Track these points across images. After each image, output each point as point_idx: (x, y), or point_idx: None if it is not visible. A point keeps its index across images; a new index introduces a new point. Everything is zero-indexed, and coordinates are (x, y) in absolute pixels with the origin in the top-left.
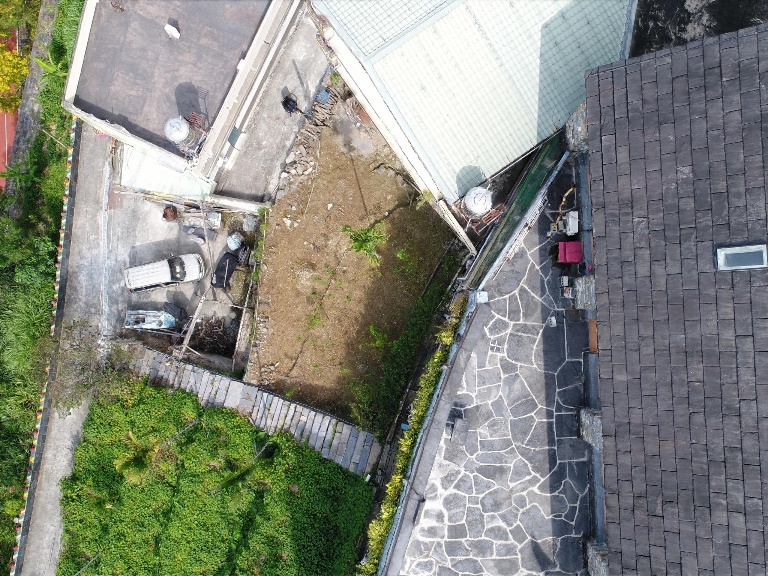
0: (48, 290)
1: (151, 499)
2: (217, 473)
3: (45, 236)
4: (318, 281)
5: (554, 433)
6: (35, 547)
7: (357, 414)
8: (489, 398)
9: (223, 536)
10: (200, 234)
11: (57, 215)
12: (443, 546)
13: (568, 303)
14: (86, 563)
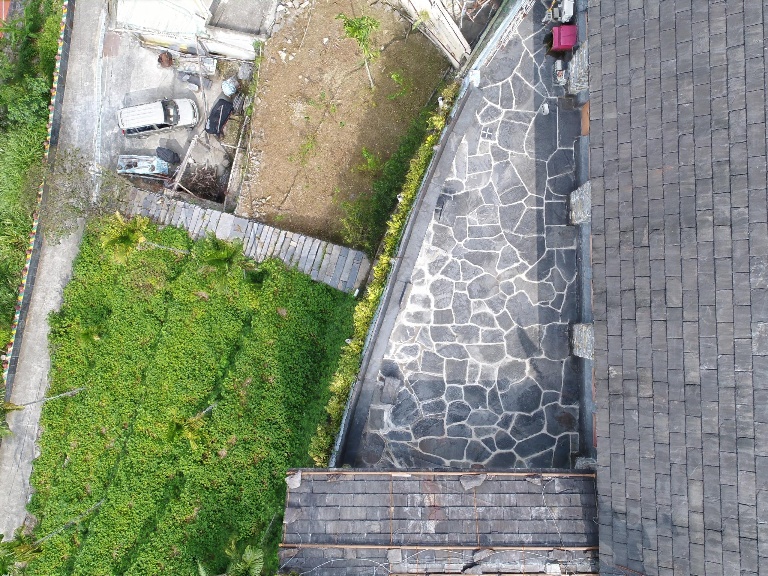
0: (40, 131)
1: (139, 332)
2: (205, 303)
3: (39, 76)
4: (312, 114)
5: (543, 221)
6: (22, 387)
7: (347, 227)
8: (479, 185)
9: (210, 365)
10: (195, 82)
11: (52, 70)
12: (429, 331)
13: (561, 91)
14: (72, 398)
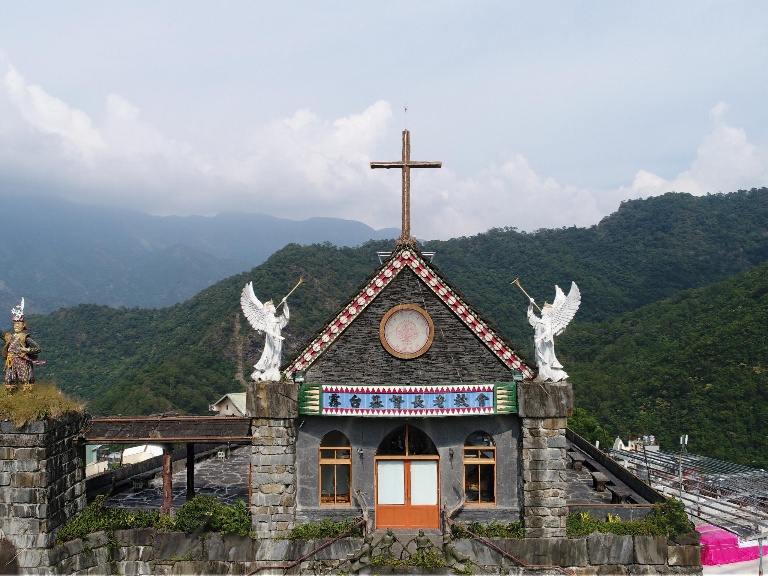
0: None
1: None
2: None
3: None
4: None
5: None
6: None
7: None
8: None
9: None
10: None
11: None
12: None
13: None
14: None
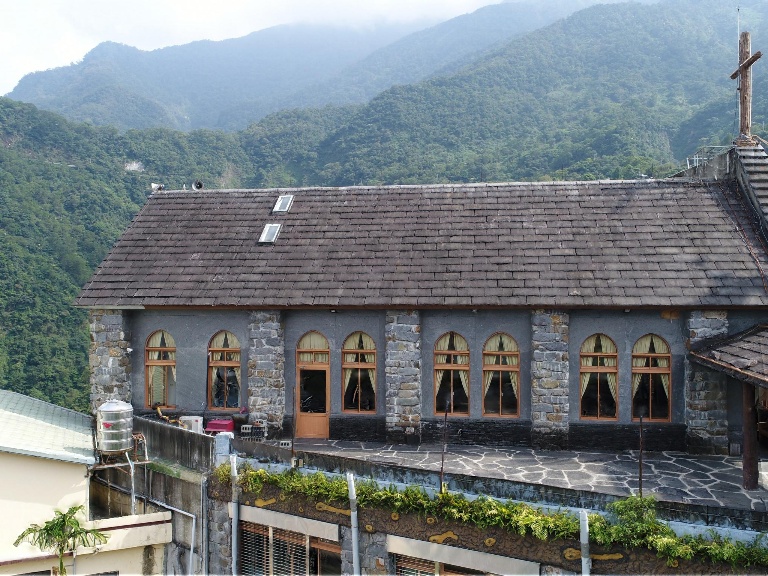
0: None
1: None
2: None
3: None
4: None
5: None
6: None
7: None
8: None
9: None
10: None
11: None
12: None
13: None
14: None
